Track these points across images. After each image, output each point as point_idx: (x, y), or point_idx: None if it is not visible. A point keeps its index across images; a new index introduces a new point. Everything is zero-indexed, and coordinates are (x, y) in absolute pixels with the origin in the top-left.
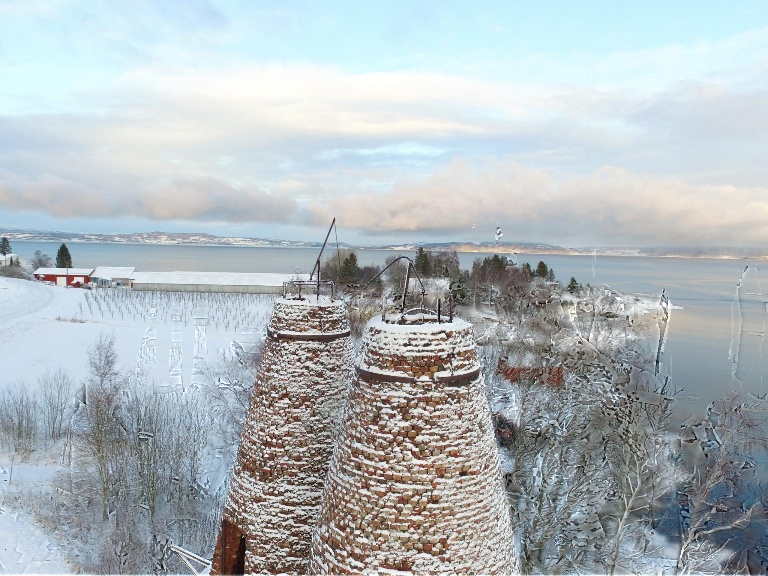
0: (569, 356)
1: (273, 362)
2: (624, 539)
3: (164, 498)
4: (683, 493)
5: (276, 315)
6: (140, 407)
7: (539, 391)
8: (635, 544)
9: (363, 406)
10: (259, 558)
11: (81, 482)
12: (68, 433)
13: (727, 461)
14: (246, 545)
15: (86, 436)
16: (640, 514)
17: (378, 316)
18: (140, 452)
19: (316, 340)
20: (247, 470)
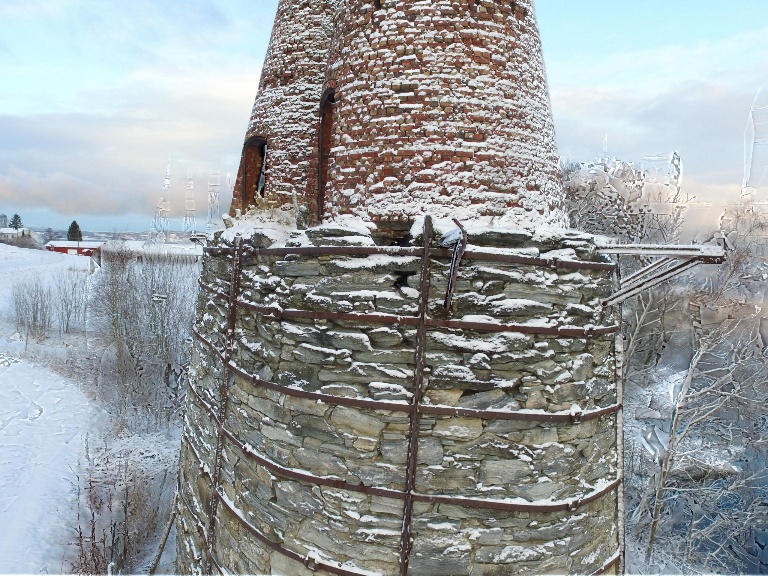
0: (581, 188)
1: None
2: (635, 354)
3: (177, 358)
4: (695, 303)
5: None
6: (154, 269)
7: None
8: (646, 359)
9: None
10: (280, 151)
11: (96, 342)
12: (83, 292)
13: None
14: (267, 144)
15: (101, 297)
16: (652, 327)
17: None
18: (154, 312)
19: None
20: (268, 84)
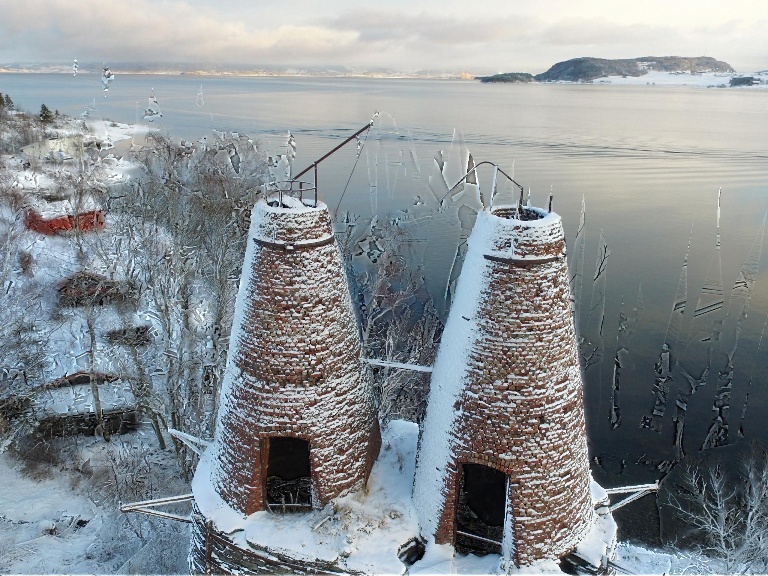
0: None
1: (295, 274)
2: None
3: None
4: None
5: (283, 226)
6: None
7: (243, 241)
8: None
9: (525, 286)
10: (328, 449)
11: None
12: None
13: (389, 262)
14: (312, 445)
15: None
16: None
17: (493, 215)
18: None
19: (329, 243)
20: (289, 383)
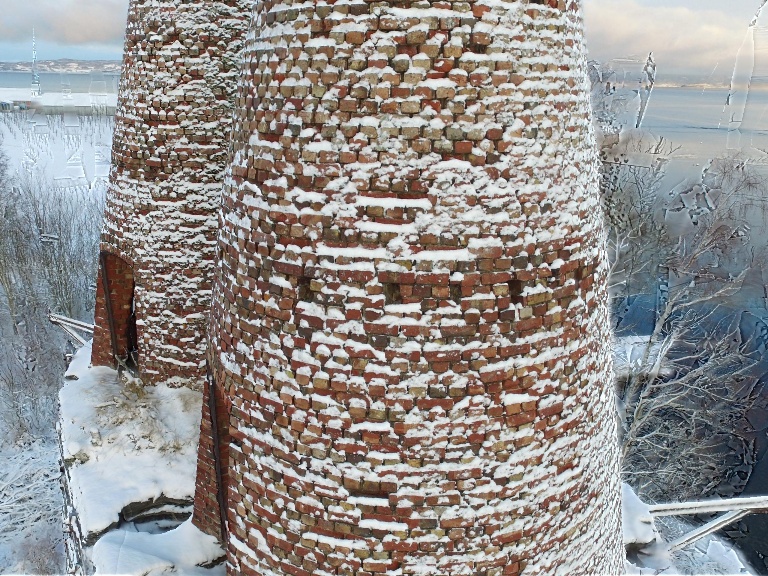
0: None
1: None
2: None
3: (82, 307)
4: (665, 266)
5: None
6: (37, 205)
7: None
8: None
9: None
10: (156, 294)
11: None
12: None
13: None
14: (134, 278)
15: None
16: (616, 291)
17: None
18: (45, 257)
19: None
20: (125, 169)
